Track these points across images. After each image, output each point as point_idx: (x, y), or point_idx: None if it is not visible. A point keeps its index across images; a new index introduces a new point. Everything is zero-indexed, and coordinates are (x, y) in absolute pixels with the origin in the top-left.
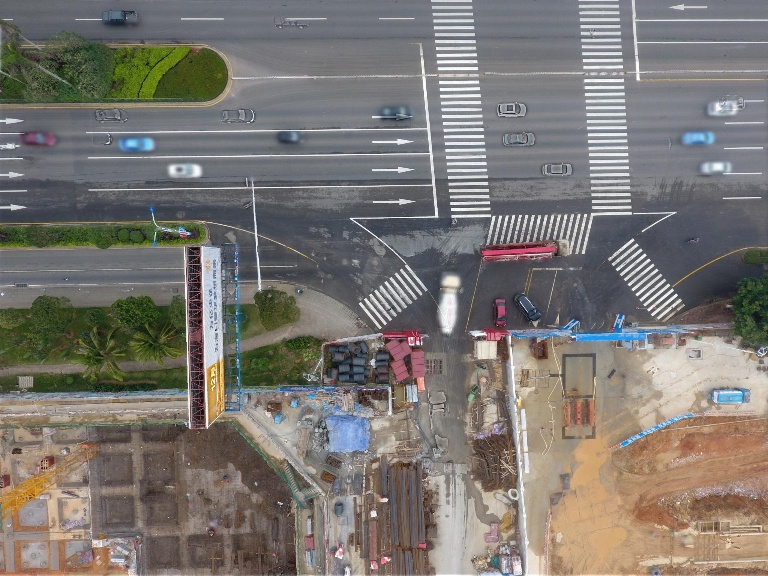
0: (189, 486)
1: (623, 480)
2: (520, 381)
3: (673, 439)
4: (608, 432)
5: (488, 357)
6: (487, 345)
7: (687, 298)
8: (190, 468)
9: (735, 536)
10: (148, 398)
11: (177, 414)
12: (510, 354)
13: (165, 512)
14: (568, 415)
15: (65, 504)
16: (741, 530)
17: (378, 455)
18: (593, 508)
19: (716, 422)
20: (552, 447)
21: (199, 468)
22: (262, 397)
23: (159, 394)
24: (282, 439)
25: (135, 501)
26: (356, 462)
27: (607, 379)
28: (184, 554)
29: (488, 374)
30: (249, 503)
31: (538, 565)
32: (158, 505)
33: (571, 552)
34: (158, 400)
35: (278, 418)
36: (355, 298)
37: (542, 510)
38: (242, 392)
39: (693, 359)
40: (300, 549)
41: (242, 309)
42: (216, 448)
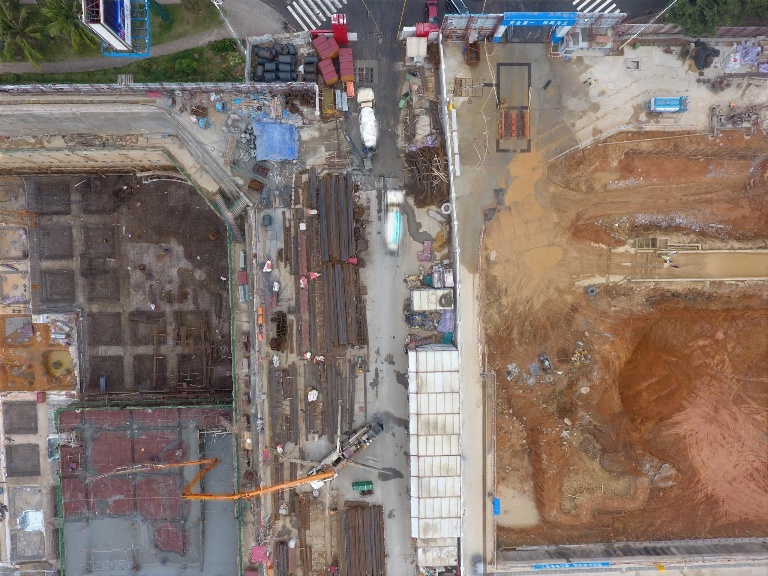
0: (131, 261)
1: (559, 196)
2: (453, 90)
3: (610, 154)
4: (544, 146)
5: (418, 54)
6: (417, 41)
7: (626, 8)
8: (131, 241)
9: (673, 254)
10: (69, 99)
11: (106, 142)
12: (441, 53)
13: (107, 289)
14: (502, 125)
15: (4, 279)
16: (679, 248)
17: (307, 167)
18: (528, 225)
19: (655, 137)
20: (486, 160)
21: (140, 241)
22: (187, 102)
23: (78, 84)
24: (208, 147)
25: (75, 275)
26: (285, 173)
27: (543, 90)
28: (126, 331)
29: (420, 83)
30: (192, 279)
31: (472, 283)
32: (99, 281)
33: (506, 271)
34: (80, 102)
35: (203, 120)
36: (283, 1)
37: (476, 226)
38: (163, 83)
39: (631, 70)
40: (233, 285)
41: (166, 9)
42: (157, 220)
